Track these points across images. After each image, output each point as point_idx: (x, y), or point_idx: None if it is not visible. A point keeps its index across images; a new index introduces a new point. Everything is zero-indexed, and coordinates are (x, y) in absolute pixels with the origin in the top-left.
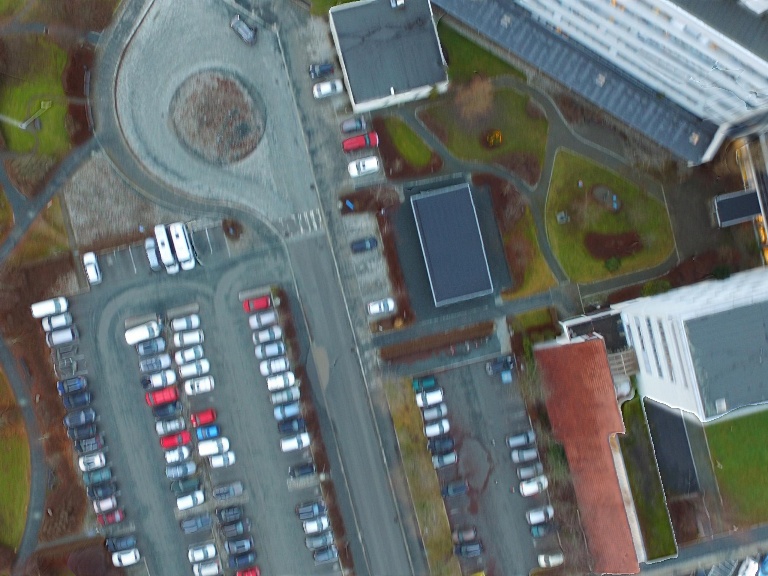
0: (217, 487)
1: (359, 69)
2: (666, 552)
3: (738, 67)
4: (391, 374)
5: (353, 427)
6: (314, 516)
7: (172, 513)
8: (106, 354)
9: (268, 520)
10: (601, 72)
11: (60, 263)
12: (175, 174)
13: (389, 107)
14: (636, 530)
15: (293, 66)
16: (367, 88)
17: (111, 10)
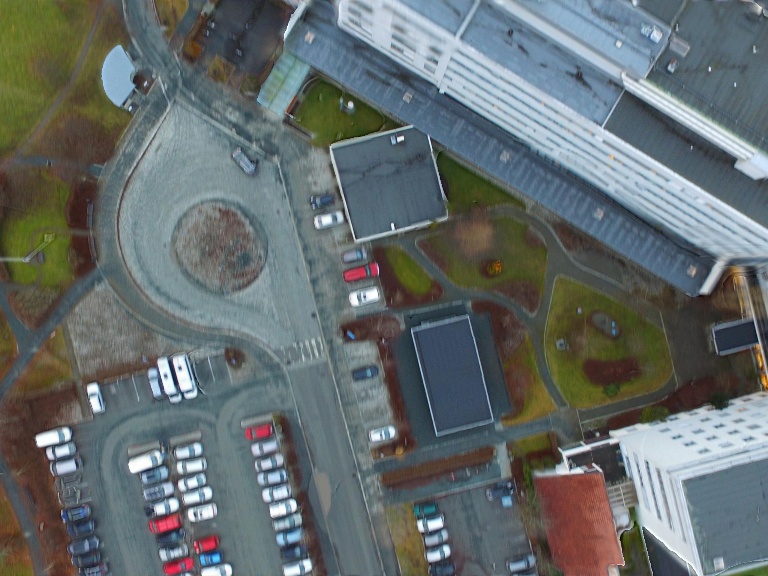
0: None
1: (360, 204)
2: None
3: (735, 226)
4: (392, 500)
5: (355, 552)
6: None
7: None
8: (110, 481)
9: None
10: (599, 206)
11: (64, 393)
12: (177, 303)
13: (389, 236)
14: None
15: (294, 196)
16: (368, 223)
17: (113, 143)
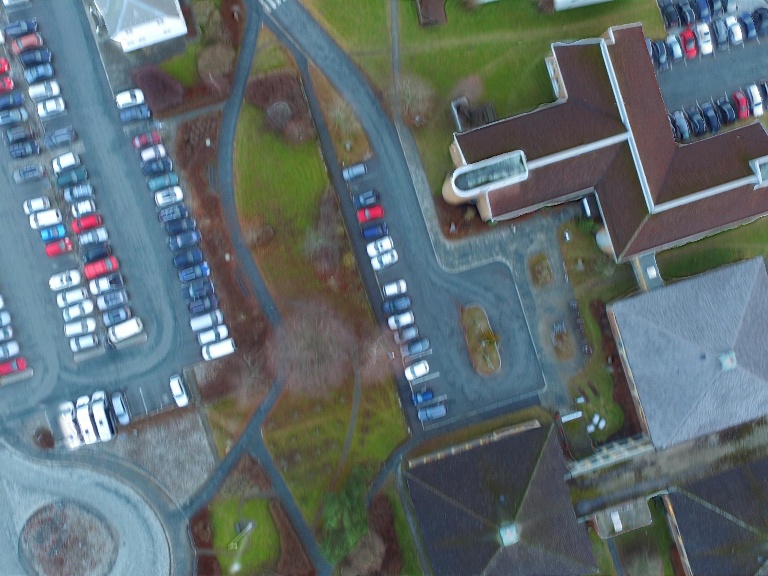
0: None
1: None
2: None
3: None
4: None
5: None
6: None
7: (87, 147)
8: (165, 305)
9: None
10: None
11: (211, 394)
12: (108, 488)
13: None
14: None
15: None
16: None
17: None
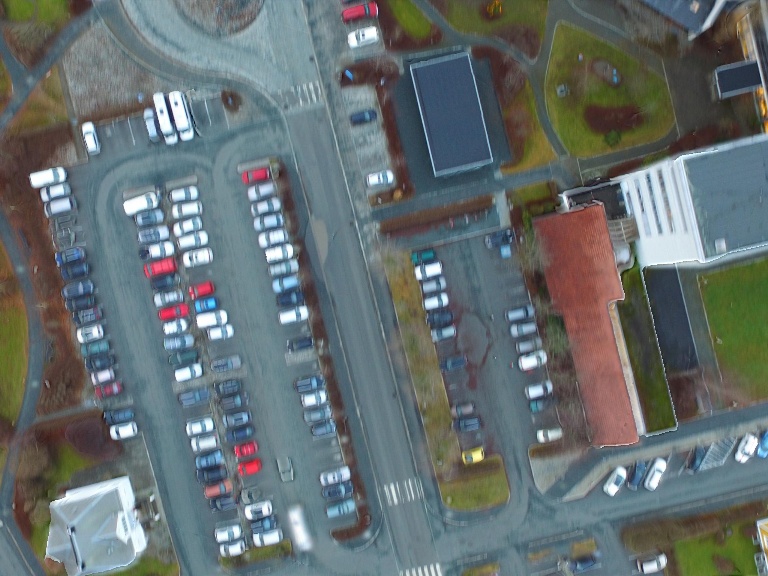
0: (215, 359)
1: None
2: (665, 424)
3: None
4: (390, 247)
5: (352, 301)
6: (312, 389)
7: (170, 387)
8: (104, 226)
9: (266, 395)
10: None
11: (59, 132)
12: (174, 45)
13: None
14: (635, 402)
15: None
16: None
17: None
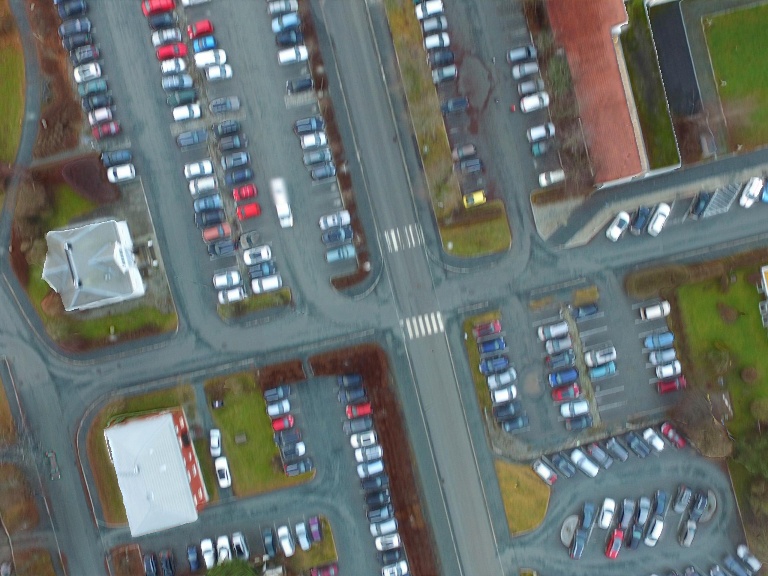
0: (214, 99)
1: None
2: (669, 161)
3: None
4: None
5: (352, 43)
6: (312, 130)
7: (168, 129)
8: None
9: (265, 139)
10: None
11: None
12: None
13: None
14: (638, 138)
15: None
16: None
17: None
